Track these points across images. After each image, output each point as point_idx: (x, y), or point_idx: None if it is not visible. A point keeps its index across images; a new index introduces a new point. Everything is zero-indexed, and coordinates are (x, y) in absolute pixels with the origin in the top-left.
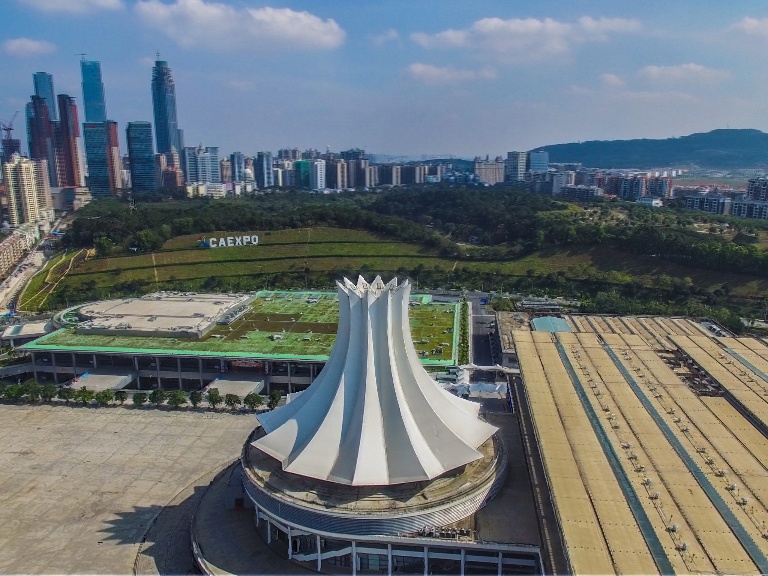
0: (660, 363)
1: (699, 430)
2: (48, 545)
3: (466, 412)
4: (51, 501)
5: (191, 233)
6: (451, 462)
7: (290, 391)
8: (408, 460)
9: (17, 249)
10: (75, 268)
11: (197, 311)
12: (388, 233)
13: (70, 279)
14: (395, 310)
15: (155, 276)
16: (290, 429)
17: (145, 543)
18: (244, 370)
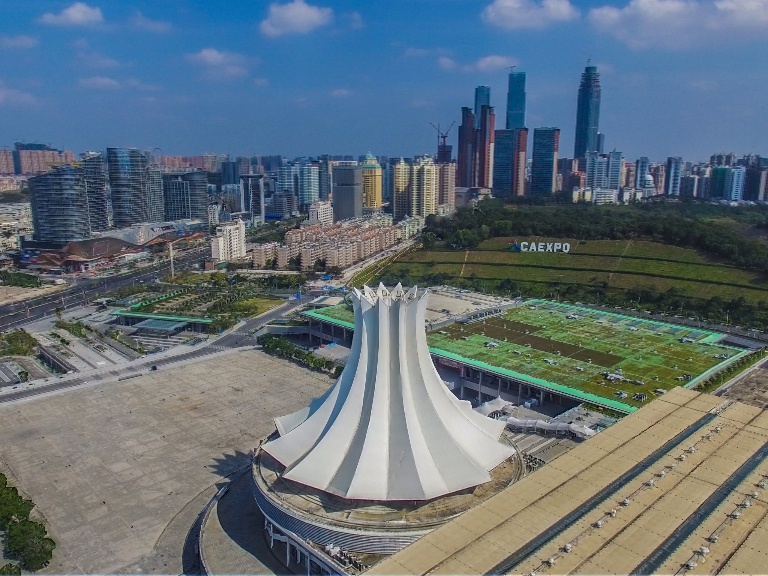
0: None
1: (714, 575)
2: (180, 456)
3: (487, 454)
4: (214, 427)
5: (508, 235)
6: (397, 493)
7: (480, 400)
8: (349, 473)
9: (390, 237)
10: (402, 257)
11: (449, 307)
12: (720, 255)
13: (394, 265)
14: (393, 321)
15: (461, 272)
16: (304, 415)
17: (226, 478)
18: (449, 369)
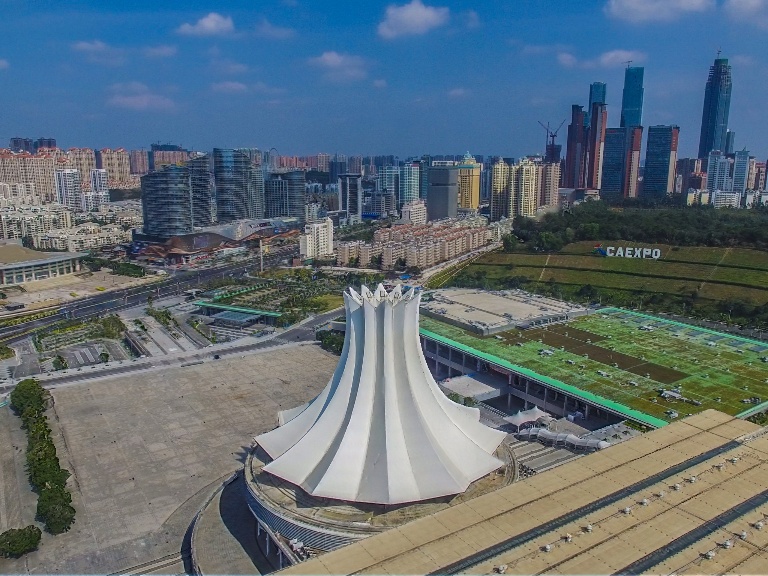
0: None
1: None
2: (213, 441)
3: (472, 464)
4: (252, 417)
5: (595, 239)
6: (365, 495)
7: (526, 409)
8: (322, 471)
9: (479, 238)
10: (481, 258)
11: (513, 312)
12: None
13: (472, 267)
14: (379, 322)
15: (540, 276)
16: None
17: None
18: (499, 375)
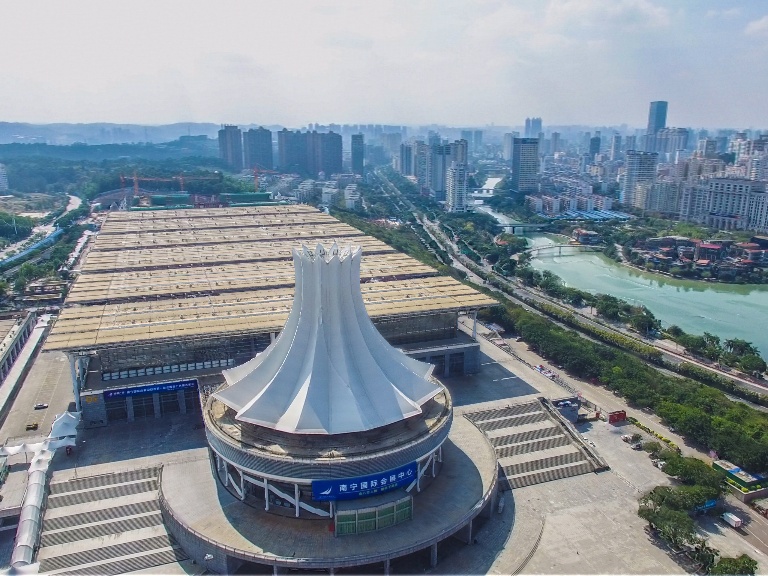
0: (158, 302)
1: None
2: None
3: None
4: None
5: None
6: None
7: None
8: None
9: None
10: None
11: None
12: None
13: None
14: None
15: None
16: None
17: None
18: None
